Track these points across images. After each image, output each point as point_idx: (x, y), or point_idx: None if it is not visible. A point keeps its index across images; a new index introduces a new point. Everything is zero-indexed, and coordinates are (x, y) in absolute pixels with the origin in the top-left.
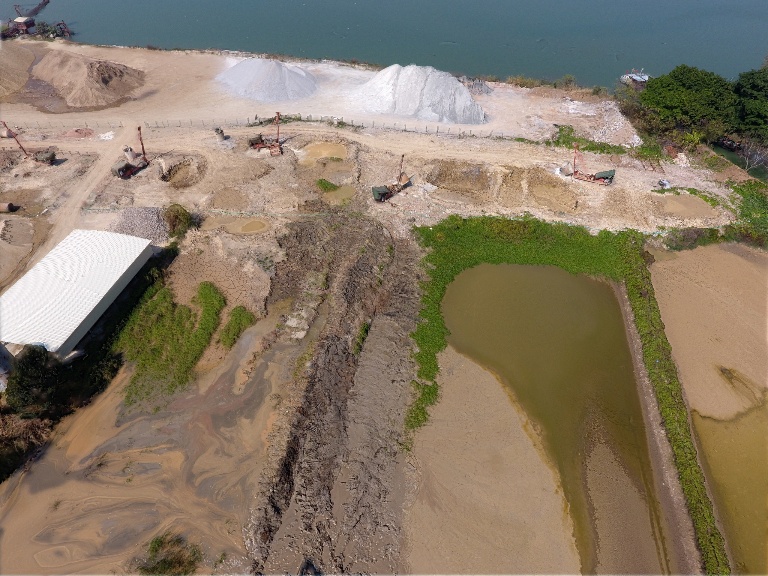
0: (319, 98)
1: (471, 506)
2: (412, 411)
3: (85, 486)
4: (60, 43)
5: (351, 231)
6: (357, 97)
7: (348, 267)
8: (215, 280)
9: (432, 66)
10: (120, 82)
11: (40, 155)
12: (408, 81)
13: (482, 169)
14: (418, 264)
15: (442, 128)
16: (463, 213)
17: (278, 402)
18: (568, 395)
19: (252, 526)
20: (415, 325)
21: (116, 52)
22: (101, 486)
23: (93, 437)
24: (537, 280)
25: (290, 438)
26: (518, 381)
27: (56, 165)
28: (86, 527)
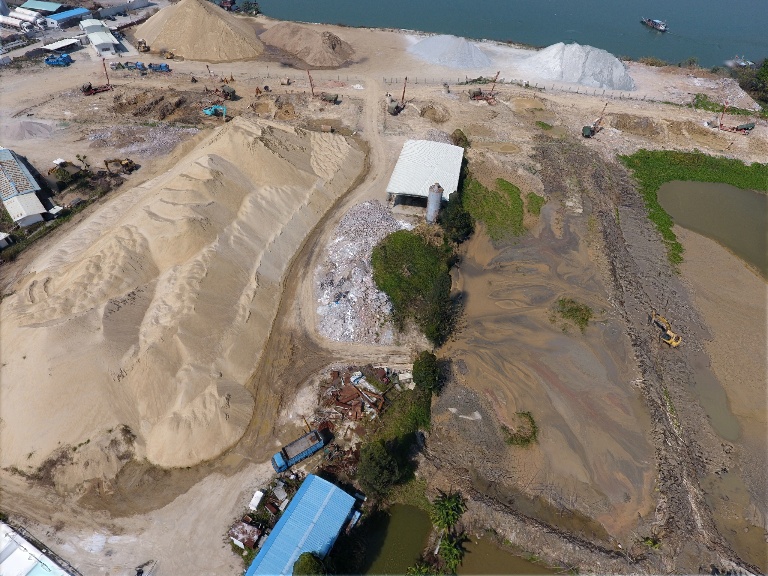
0: (498, 67)
1: (731, 301)
2: (671, 255)
3: (500, 276)
4: (264, 19)
5: (577, 155)
6: (527, 68)
7: (591, 175)
8: (504, 178)
9: (590, 45)
10: (341, 49)
11: (327, 96)
12: (573, 56)
13: (649, 121)
14: (630, 178)
15: (604, 92)
16: (649, 148)
17: (588, 244)
18: (767, 253)
19: (612, 298)
20: (647, 212)
21: (314, 27)
22: (509, 276)
23: (486, 254)
24: (717, 192)
25: (609, 260)
26: (731, 244)
27: (337, 104)
28: (515, 293)
